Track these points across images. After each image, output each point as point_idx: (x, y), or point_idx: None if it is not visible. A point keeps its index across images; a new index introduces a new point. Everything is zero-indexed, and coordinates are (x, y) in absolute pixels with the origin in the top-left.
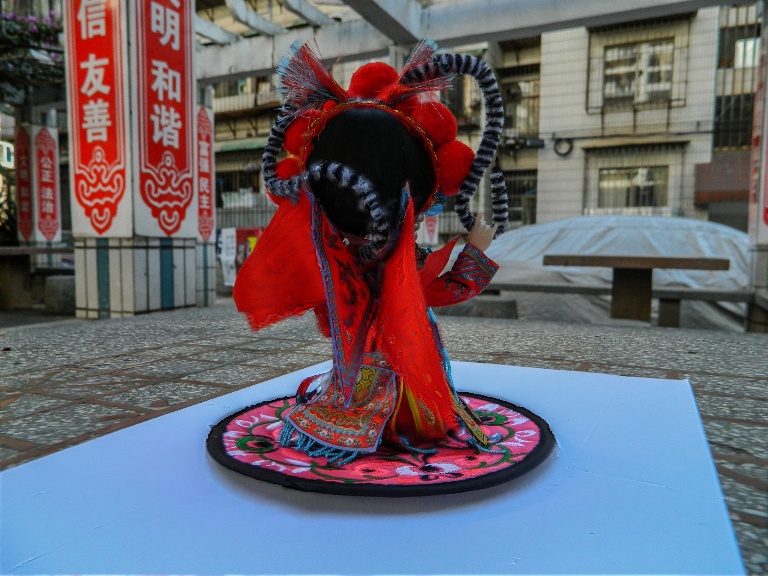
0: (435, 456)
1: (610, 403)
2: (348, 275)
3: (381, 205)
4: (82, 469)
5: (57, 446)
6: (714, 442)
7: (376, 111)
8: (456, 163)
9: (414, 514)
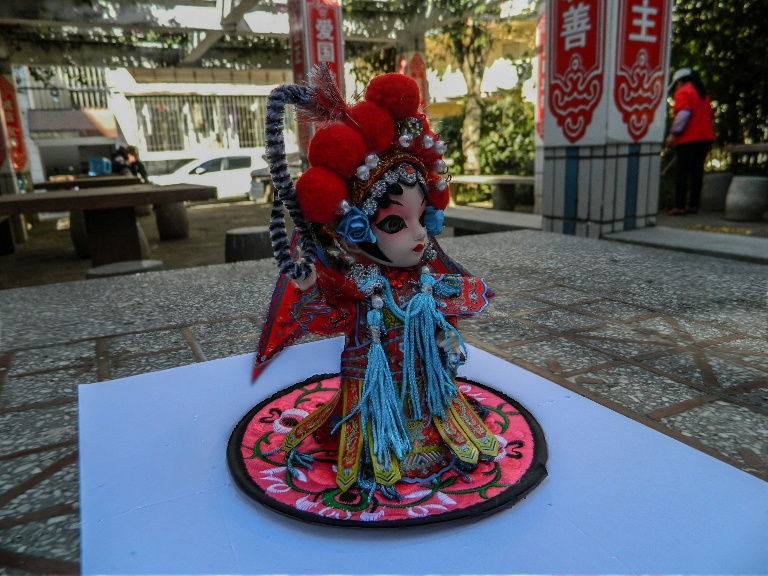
0: None
1: None
2: None
3: None
4: None
5: None
6: None
7: None
8: None
9: None
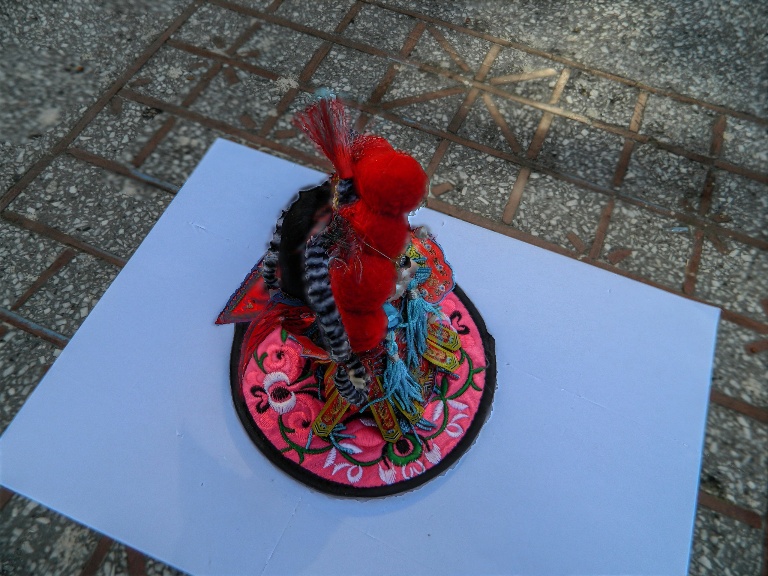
0: (312, 399)
1: None
2: None
3: None
4: None
5: None
6: None
7: (293, 222)
8: None
9: None
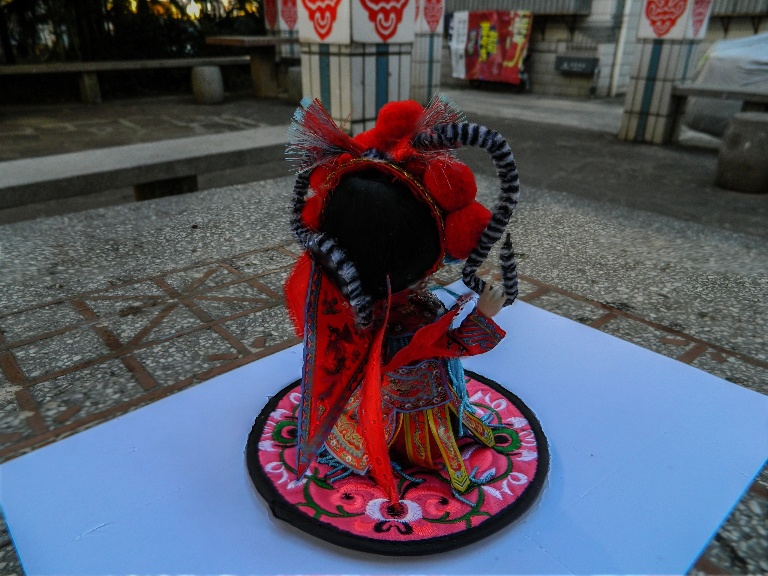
0: (417, 488)
1: (663, 435)
2: (340, 341)
3: (368, 288)
4: (169, 427)
5: (167, 390)
6: (722, 538)
7: (372, 189)
8: (461, 237)
9: (354, 561)
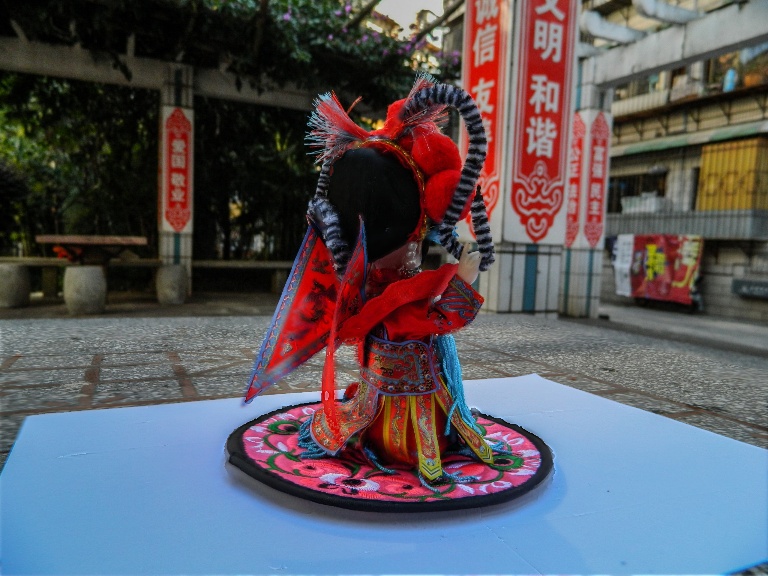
0: (386, 476)
1: (713, 492)
2: (323, 296)
3: (347, 236)
4: (186, 415)
5: (202, 398)
6: None
7: (360, 150)
8: (437, 194)
9: (287, 509)
